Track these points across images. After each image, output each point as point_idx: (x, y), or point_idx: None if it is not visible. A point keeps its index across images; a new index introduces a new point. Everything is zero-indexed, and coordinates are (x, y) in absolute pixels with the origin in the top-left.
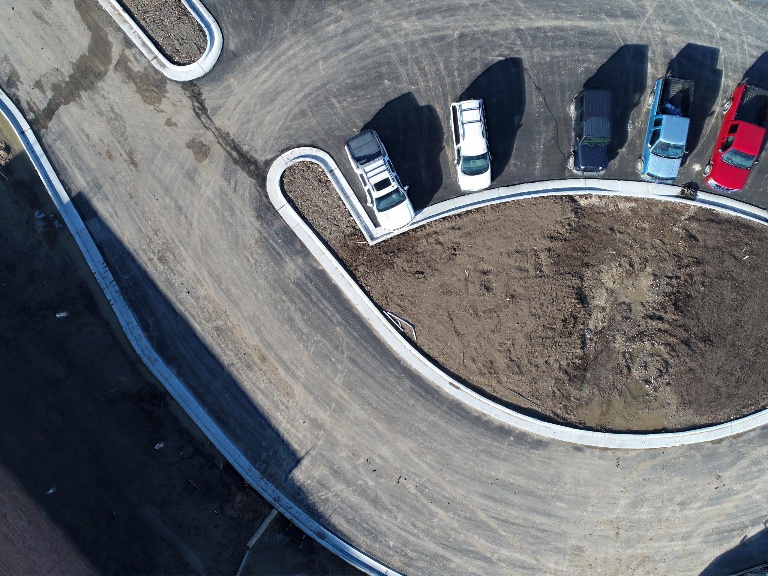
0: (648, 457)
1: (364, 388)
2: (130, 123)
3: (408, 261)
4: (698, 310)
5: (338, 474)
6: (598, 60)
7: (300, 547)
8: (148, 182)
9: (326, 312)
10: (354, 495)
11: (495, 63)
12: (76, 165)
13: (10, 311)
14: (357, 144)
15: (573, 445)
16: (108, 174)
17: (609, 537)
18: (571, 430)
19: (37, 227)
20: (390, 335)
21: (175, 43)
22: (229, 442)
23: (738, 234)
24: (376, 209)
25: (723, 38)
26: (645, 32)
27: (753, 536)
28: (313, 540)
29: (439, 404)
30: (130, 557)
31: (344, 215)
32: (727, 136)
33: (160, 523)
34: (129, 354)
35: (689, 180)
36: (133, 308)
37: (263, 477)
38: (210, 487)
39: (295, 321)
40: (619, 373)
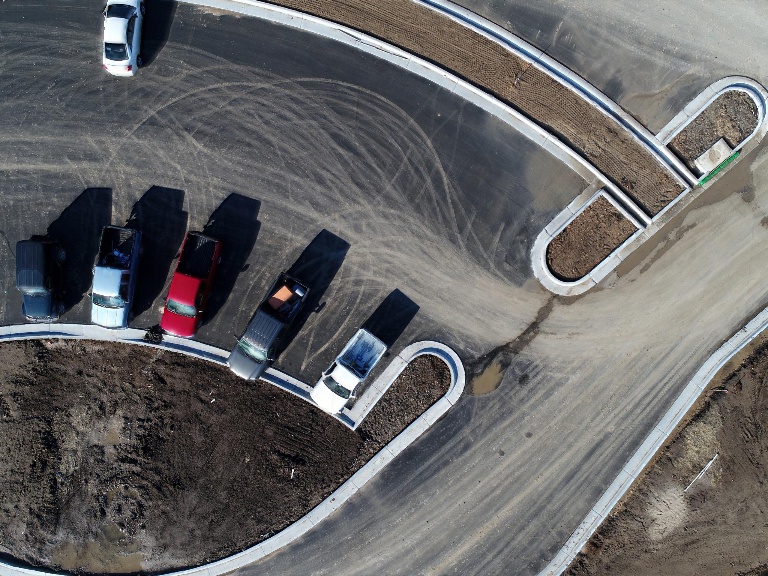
0: None
1: None
2: None
3: None
4: (169, 453)
5: None
6: (61, 204)
7: None
8: None
9: None
10: None
11: None
12: None
13: None
14: None
15: None
16: None
17: None
18: (45, 574)
19: None
20: None
21: None
22: None
23: (205, 377)
24: None
25: (188, 180)
26: (108, 175)
27: None
28: None
29: None
30: None
31: None
32: None
33: None
34: None
35: (155, 323)
36: None
37: None
38: None
39: None
40: (93, 516)
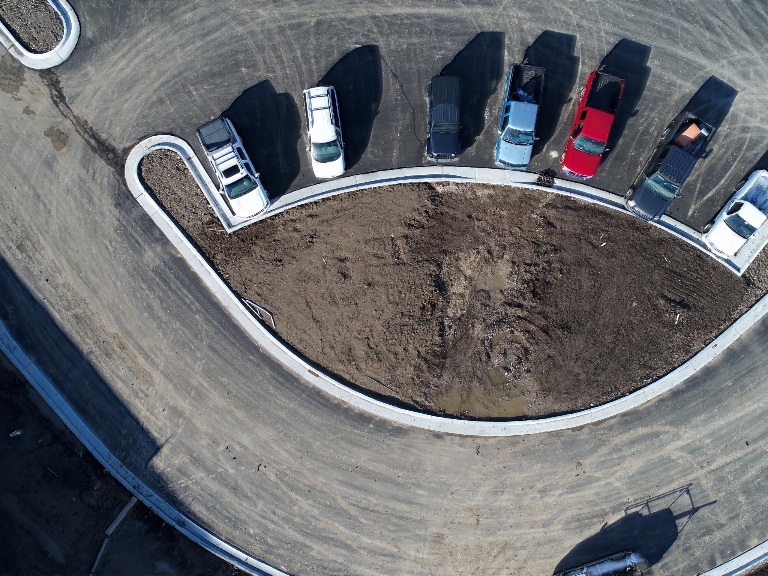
0: (508, 444)
1: (223, 376)
2: None
3: (266, 249)
4: (556, 297)
5: (198, 462)
6: (455, 47)
7: (159, 535)
8: (6, 170)
9: (185, 300)
10: (214, 483)
11: (352, 50)
12: None
13: None
14: (208, 131)
15: (433, 432)
16: None
17: (469, 524)
18: (431, 417)
19: None
20: (249, 323)
21: (32, 31)
22: (88, 430)
23: (595, 221)
24: (228, 196)
25: (580, 25)
26: (502, 19)
27: (614, 523)
28: (173, 528)
29: (299, 392)
30: None
31: (202, 203)
32: (578, 123)
33: (19, 511)
34: None
35: (546, 167)
36: None
37: (123, 465)
38: (69, 475)
39: (154, 309)
40: (478, 360)
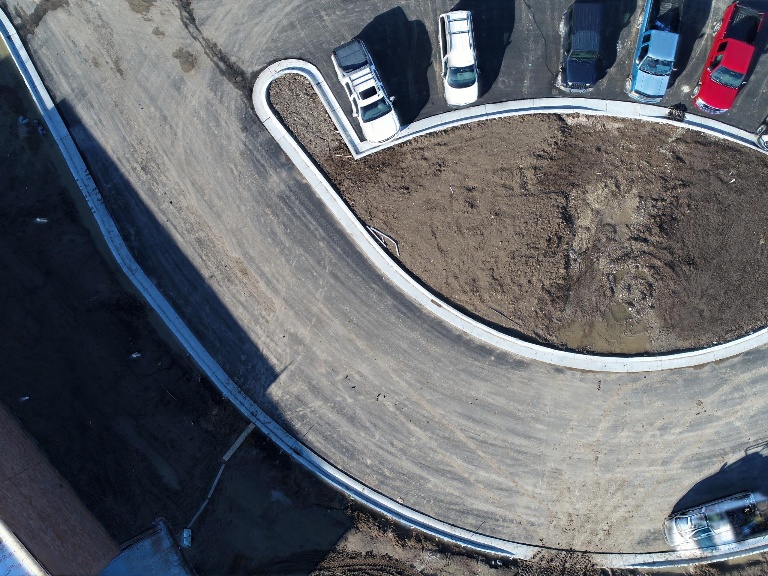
0: (630, 381)
1: (345, 304)
2: (117, 31)
3: (393, 176)
4: (683, 233)
5: (317, 390)
6: None
7: (277, 462)
8: (133, 90)
9: (309, 226)
10: (333, 411)
11: None
12: (62, 71)
13: None
14: (344, 53)
15: (554, 367)
16: (93, 81)
17: (588, 461)
18: (553, 351)
19: (21, 132)
20: (373, 251)
21: None
22: (208, 354)
23: (725, 157)
24: (361, 119)
25: None
26: None
27: (733, 463)
28: (290, 455)
29: (420, 322)
30: (105, 467)
31: (330, 128)
32: (716, 55)
33: (136, 434)
34: (110, 263)
35: (677, 102)
36: (115, 217)
37: (241, 391)
38: (188, 399)
39: (278, 234)
40: (602, 295)
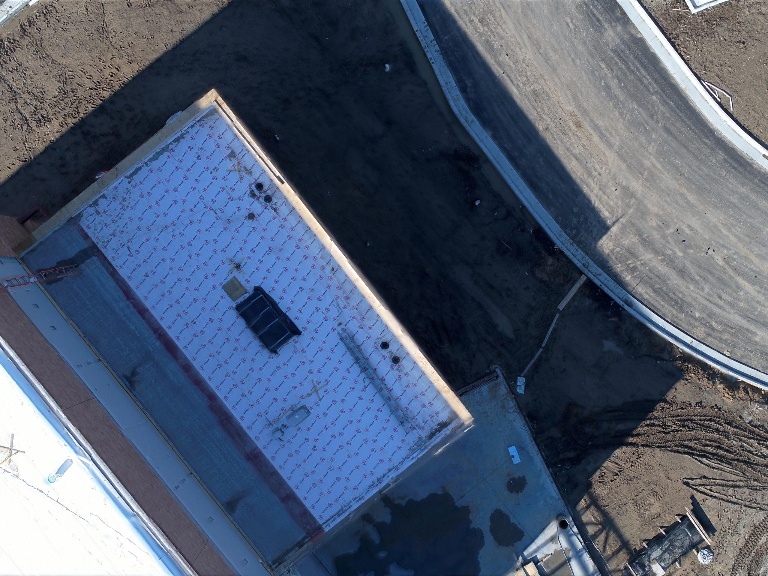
0: None
1: (677, 158)
2: None
3: (729, 30)
4: None
5: (647, 243)
6: None
7: (608, 313)
8: None
9: (643, 80)
10: (662, 265)
11: None
12: None
13: (332, 65)
14: None
15: None
16: None
17: None
18: None
19: None
20: (706, 105)
21: None
22: (541, 206)
23: None
24: None
25: None
26: None
27: None
28: (620, 307)
29: (751, 177)
30: (441, 315)
31: None
32: None
33: (472, 283)
34: (445, 115)
35: None
36: (452, 68)
37: (573, 243)
38: (522, 249)
39: (612, 88)
40: None
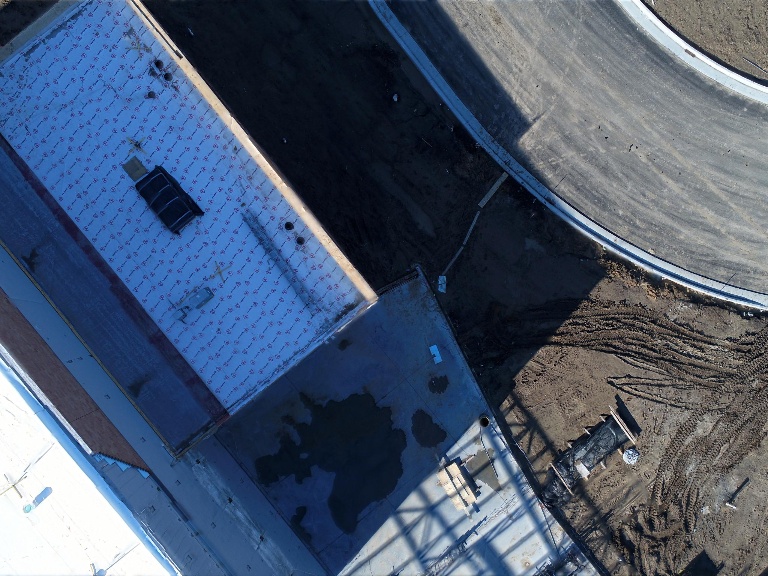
0: None
1: (599, 54)
2: None
3: None
4: None
5: (570, 140)
6: None
7: (530, 211)
8: None
9: None
10: (585, 162)
11: None
12: None
13: None
14: None
15: None
16: None
17: None
18: None
19: None
20: None
21: None
22: (462, 103)
23: None
24: None
25: None
26: None
27: None
28: (543, 205)
29: (673, 72)
30: (361, 213)
31: None
32: None
33: (391, 180)
34: (363, 11)
35: None
36: None
37: (494, 140)
38: (442, 146)
39: None
40: None
